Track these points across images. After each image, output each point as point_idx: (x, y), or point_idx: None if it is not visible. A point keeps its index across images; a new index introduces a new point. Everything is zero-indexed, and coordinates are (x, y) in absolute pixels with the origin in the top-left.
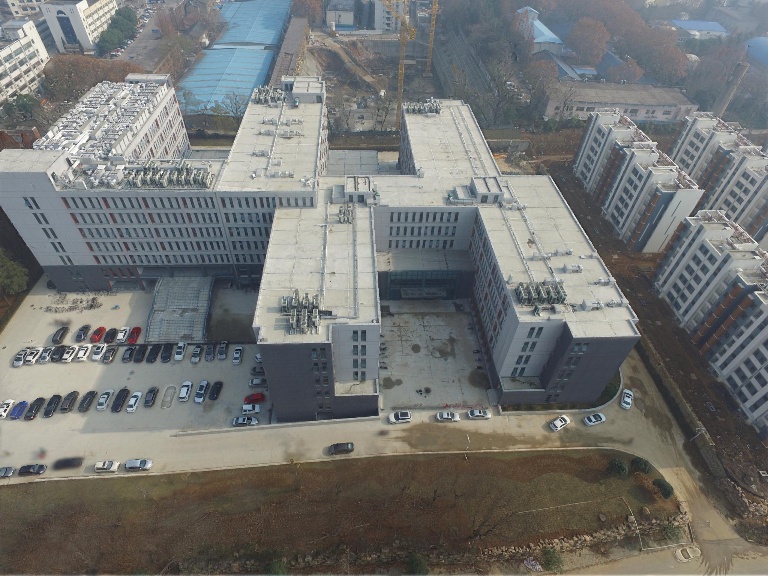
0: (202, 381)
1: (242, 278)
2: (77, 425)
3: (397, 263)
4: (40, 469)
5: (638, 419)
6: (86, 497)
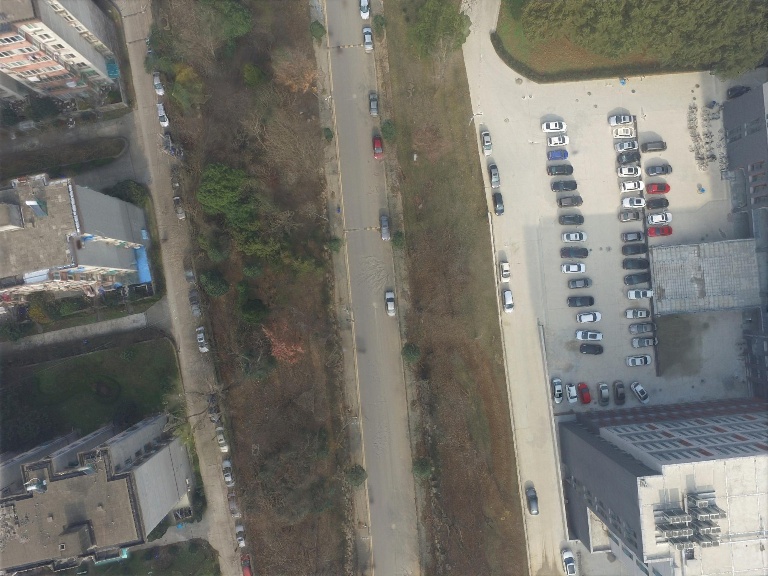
0: None
1: (762, 343)
2: (545, 221)
3: None
4: (500, 212)
5: None
6: (476, 273)
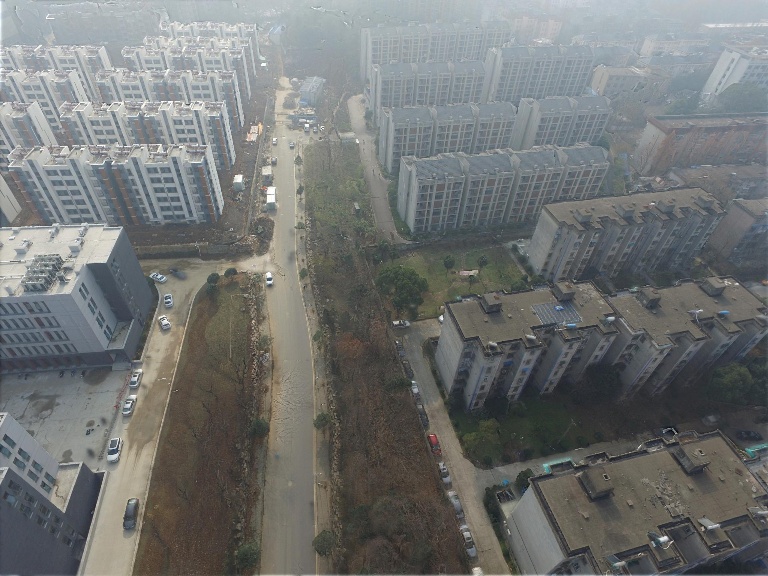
0: None
1: None
2: None
3: None
4: None
5: (177, 276)
6: None
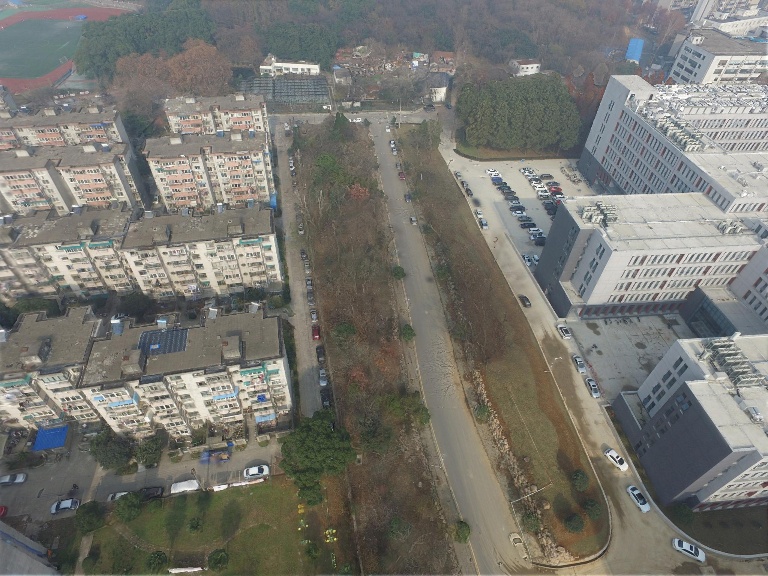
0: (545, 235)
1: None
2: (497, 200)
3: (727, 306)
4: (471, 195)
5: None
6: None
